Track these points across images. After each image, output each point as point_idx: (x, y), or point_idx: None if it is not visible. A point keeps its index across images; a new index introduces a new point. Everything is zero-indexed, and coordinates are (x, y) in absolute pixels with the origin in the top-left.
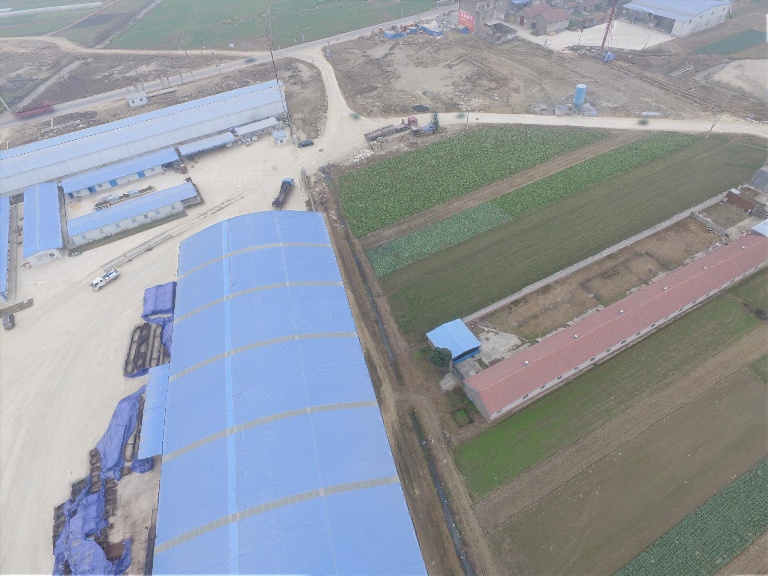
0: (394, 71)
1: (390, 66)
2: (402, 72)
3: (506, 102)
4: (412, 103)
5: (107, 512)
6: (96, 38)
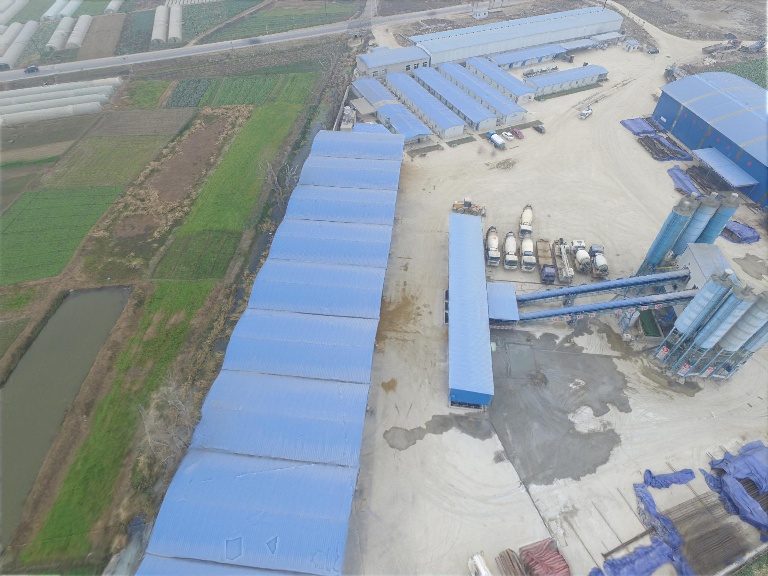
0: (679, 11)
1: (672, 8)
2: (687, 12)
3: None
4: (720, 32)
5: None
6: None
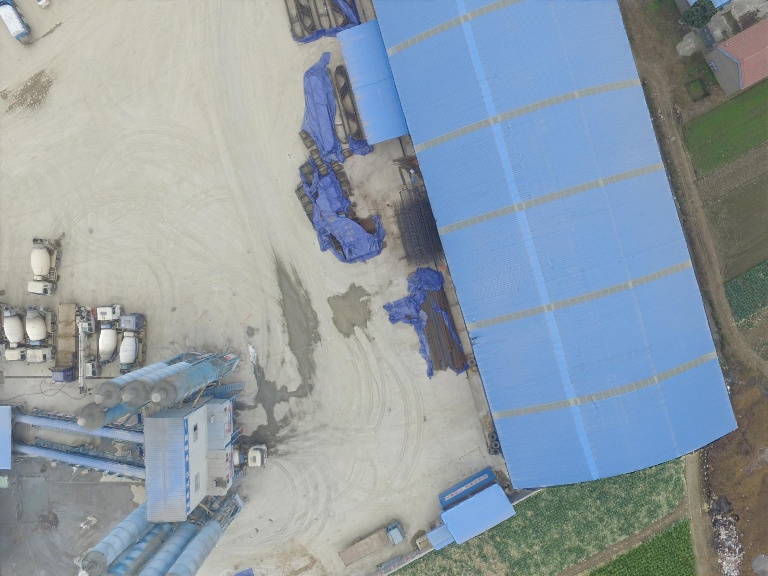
0: None
1: None
2: None
3: None
4: None
5: (346, 193)
6: None
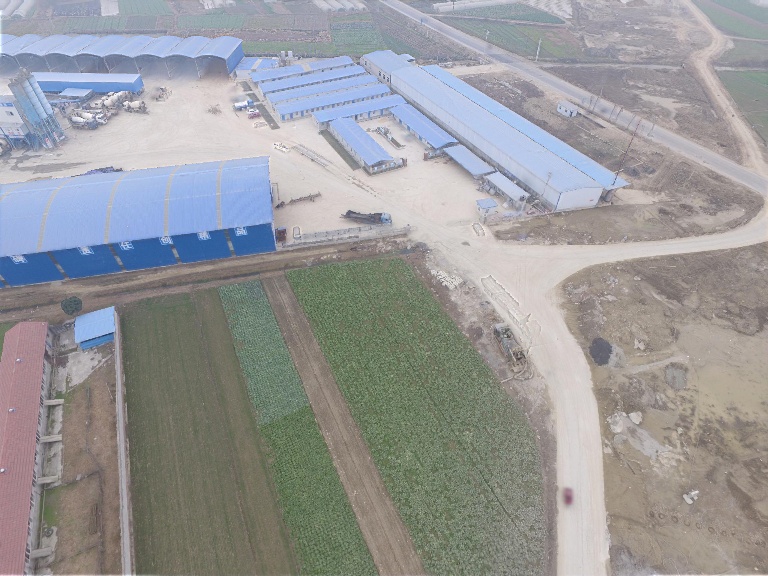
0: None
1: None
2: None
3: (672, 515)
4: (615, 338)
5: None
6: (740, 61)
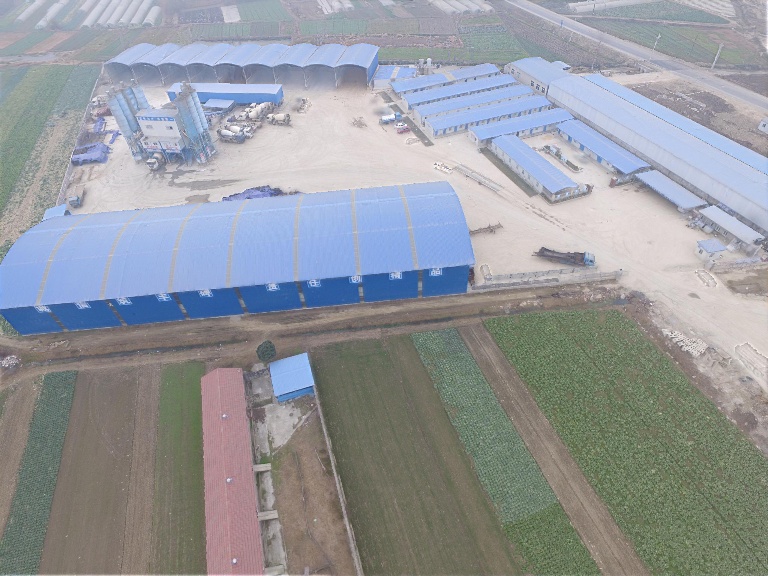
0: None
1: None
2: None
3: None
4: None
5: None
6: None
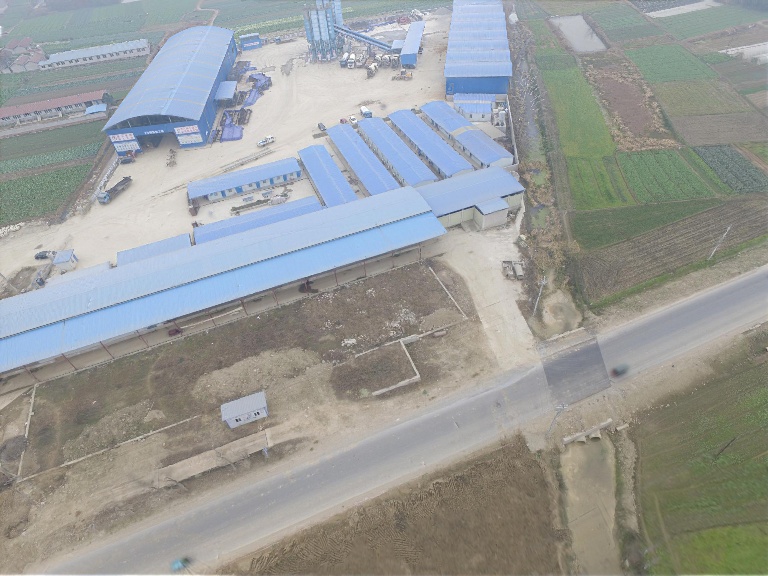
0: None
1: None
2: None
3: None
4: None
5: None
6: None
